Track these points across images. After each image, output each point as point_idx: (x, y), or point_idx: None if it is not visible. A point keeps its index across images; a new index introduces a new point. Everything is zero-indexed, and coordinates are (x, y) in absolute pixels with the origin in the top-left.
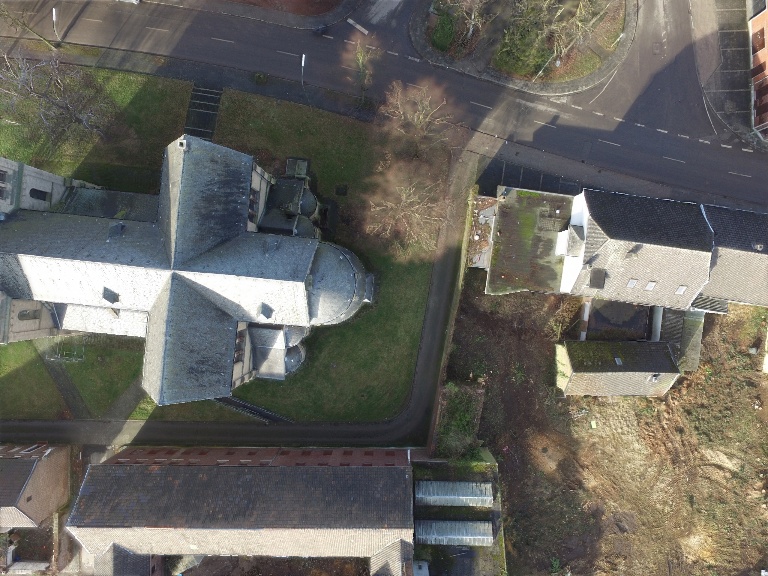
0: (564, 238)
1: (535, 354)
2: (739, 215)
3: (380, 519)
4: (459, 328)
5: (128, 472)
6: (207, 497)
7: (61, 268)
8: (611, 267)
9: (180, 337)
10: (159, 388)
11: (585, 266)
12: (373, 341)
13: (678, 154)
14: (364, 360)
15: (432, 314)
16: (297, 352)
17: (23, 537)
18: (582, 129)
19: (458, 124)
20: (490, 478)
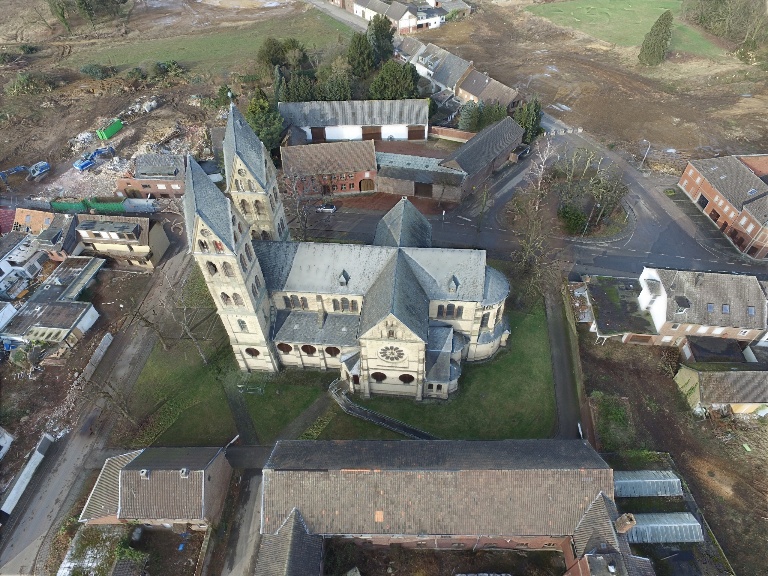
0: (644, 296)
1: (659, 388)
2: (763, 275)
3: (574, 465)
4: (584, 369)
5: (315, 444)
6: (396, 455)
7: (322, 253)
8: (688, 294)
9: (402, 283)
10: (390, 305)
11: (669, 291)
12: (513, 377)
13: (699, 267)
14: (509, 391)
15: (558, 360)
16: (457, 365)
17: (153, 575)
18: (625, 257)
19: (551, 219)
20: (667, 467)
